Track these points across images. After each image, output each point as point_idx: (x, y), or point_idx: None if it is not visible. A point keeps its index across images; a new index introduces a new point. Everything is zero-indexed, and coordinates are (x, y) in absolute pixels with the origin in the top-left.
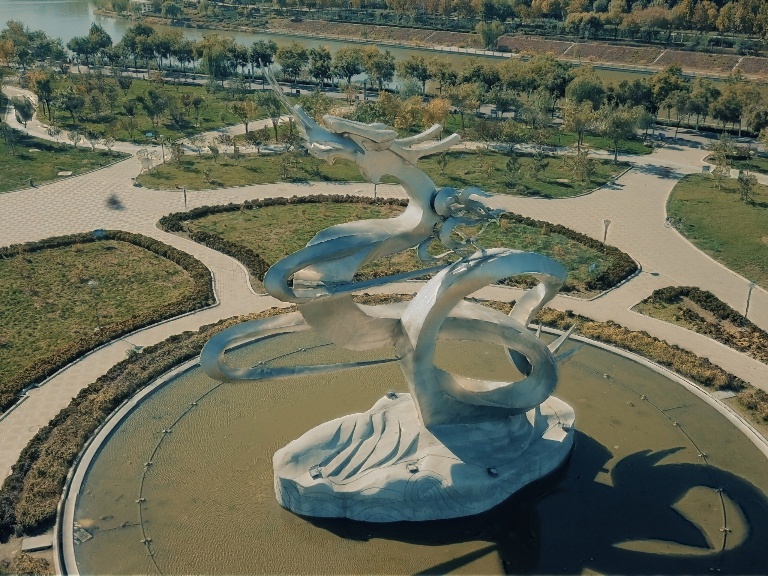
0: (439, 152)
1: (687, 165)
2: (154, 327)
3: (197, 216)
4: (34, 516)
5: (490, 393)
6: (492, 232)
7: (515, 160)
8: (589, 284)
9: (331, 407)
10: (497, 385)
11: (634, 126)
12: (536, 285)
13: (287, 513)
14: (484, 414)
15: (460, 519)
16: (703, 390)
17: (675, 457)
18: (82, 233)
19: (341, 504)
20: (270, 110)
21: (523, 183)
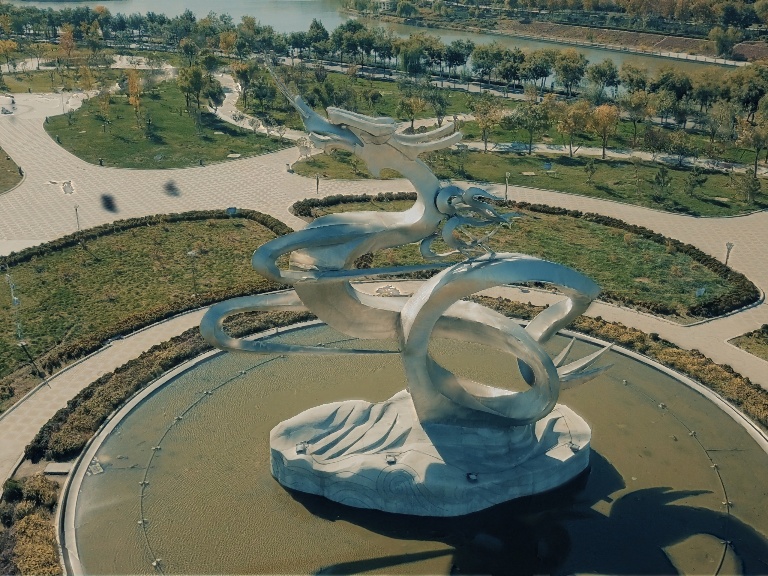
0: (600, 160)
1: None
2: None
3: (329, 203)
4: (63, 445)
5: (492, 399)
6: (612, 245)
7: (665, 173)
8: (692, 309)
9: (374, 395)
10: (502, 393)
11: None
12: (634, 304)
13: (274, 482)
14: (482, 420)
15: (431, 518)
16: (766, 436)
17: (695, 500)
18: (220, 210)
19: (320, 482)
20: (436, 108)
21: (673, 198)
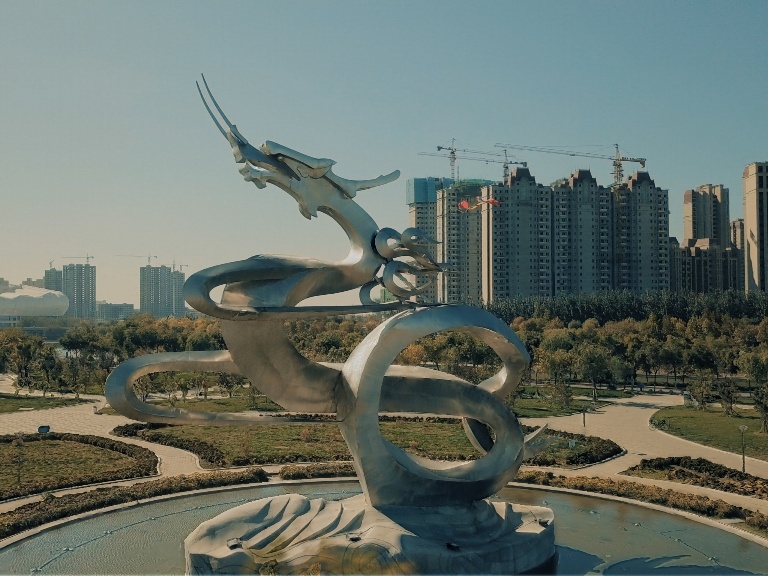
0: None
1: (669, 402)
2: (82, 488)
3: (154, 427)
4: None
5: (449, 471)
6: None
7: None
8: (570, 459)
9: None
10: (457, 464)
11: (609, 363)
12: None
13: None
14: (443, 494)
15: None
16: (706, 518)
17: (679, 561)
18: (27, 434)
19: None
20: None
21: None
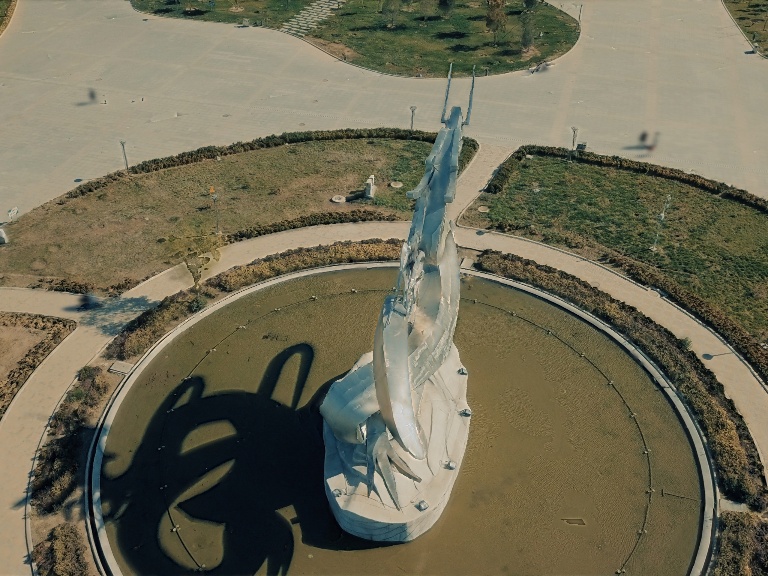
0: None
1: None
2: (755, 377)
3: None
4: None
5: None
6: None
7: None
8: None
9: None
10: None
11: None
12: None
13: None
14: None
15: None
16: None
17: None
18: None
19: None
20: None
21: None
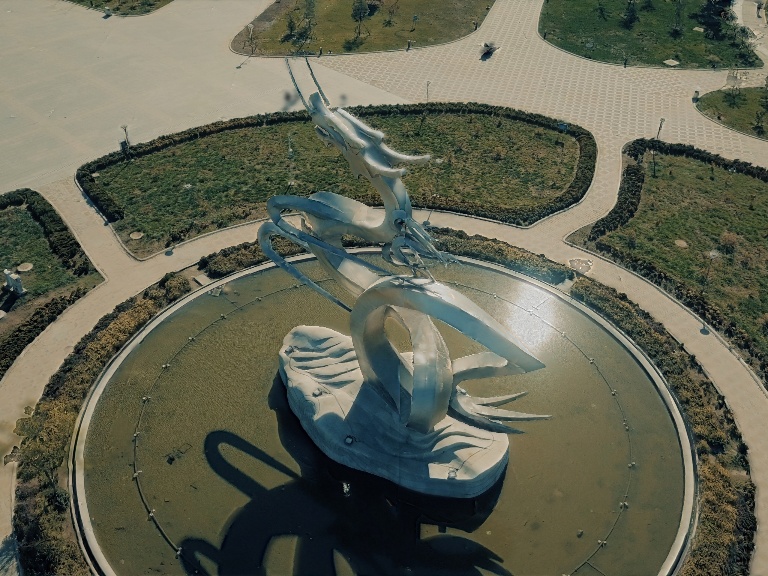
0: None
1: None
2: (462, 216)
3: (672, 151)
4: (217, 267)
5: (409, 396)
6: None
7: None
8: None
9: None
10: None
11: None
12: None
13: None
14: None
15: (318, 449)
16: None
17: None
18: (563, 121)
19: None
20: None
21: None
